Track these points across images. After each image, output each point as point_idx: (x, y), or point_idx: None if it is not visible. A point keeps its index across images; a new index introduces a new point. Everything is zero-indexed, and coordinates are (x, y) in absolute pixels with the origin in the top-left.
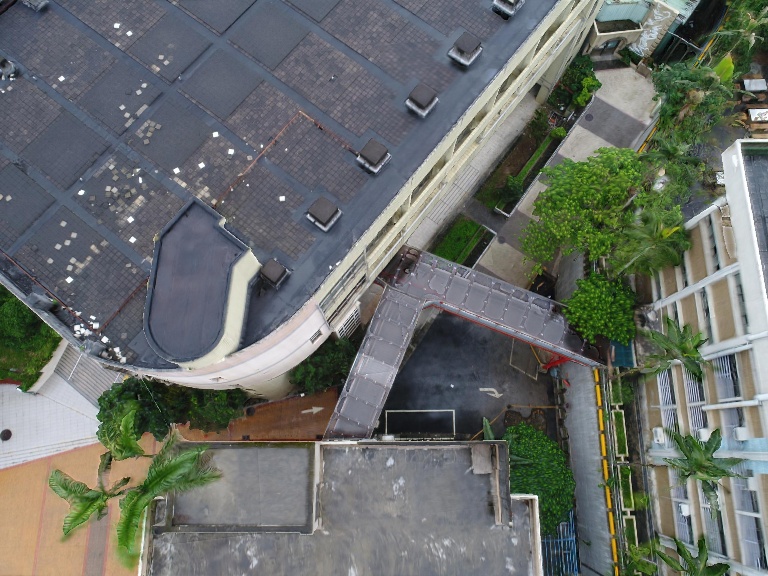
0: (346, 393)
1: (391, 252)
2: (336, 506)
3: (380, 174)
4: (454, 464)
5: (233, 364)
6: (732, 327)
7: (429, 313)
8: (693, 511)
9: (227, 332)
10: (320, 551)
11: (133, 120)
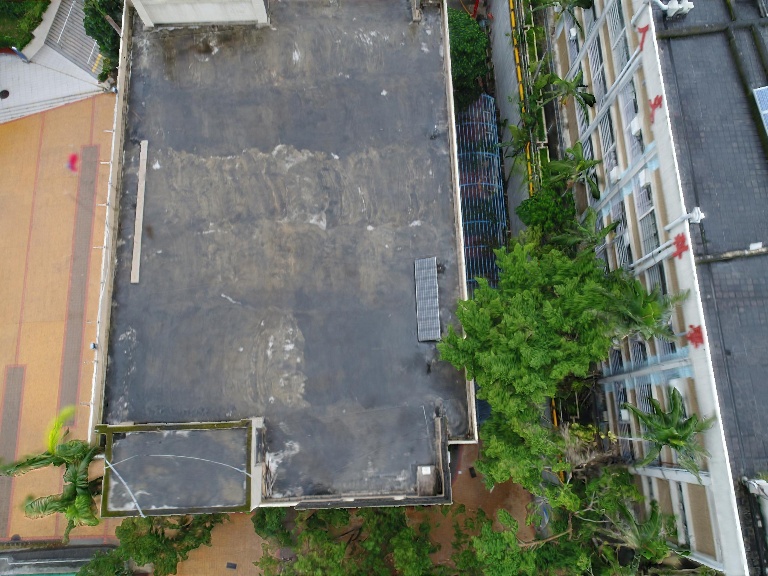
0: None
1: None
2: (282, 11)
3: None
4: None
5: None
6: None
7: None
8: None
9: None
10: (269, 41)
11: None
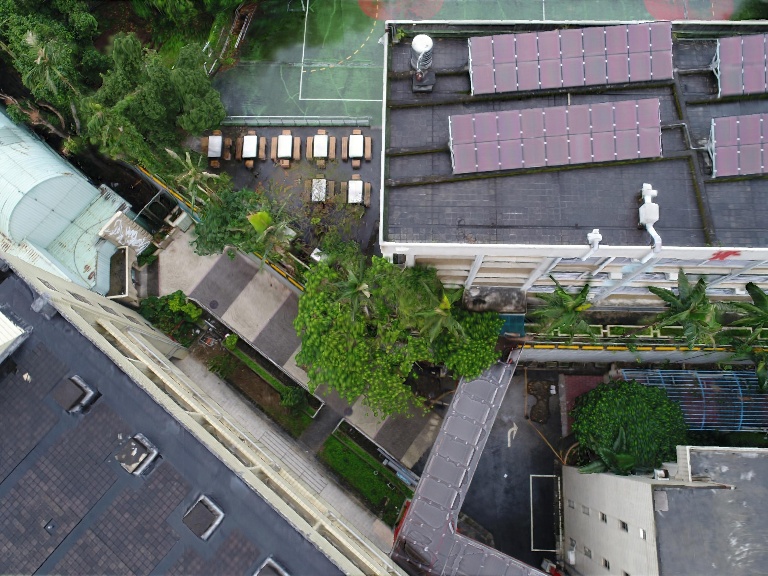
0: None
1: None
2: None
3: None
4: None
5: None
6: None
7: None
8: (669, 285)
9: None
10: None
11: None
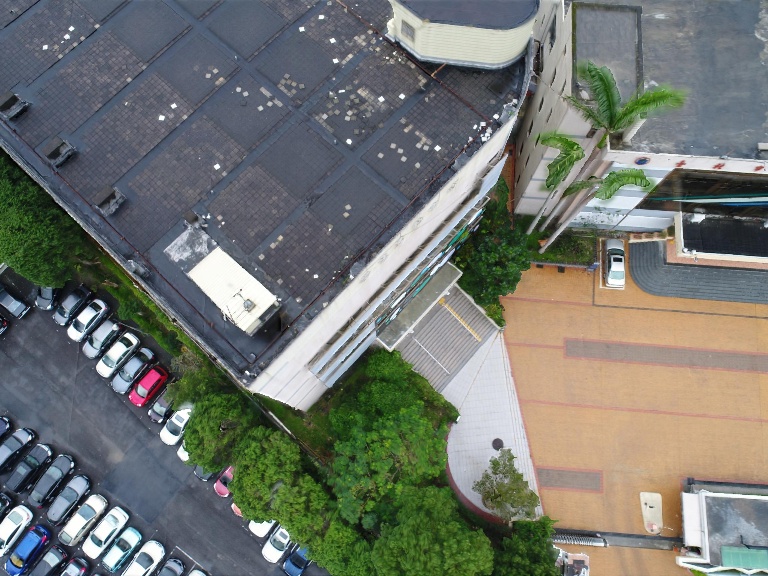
0: None
1: None
2: None
3: None
4: None
5: None
6: None
7: None
8: None
9: None
10: (643, 37)
11: (276, 100)
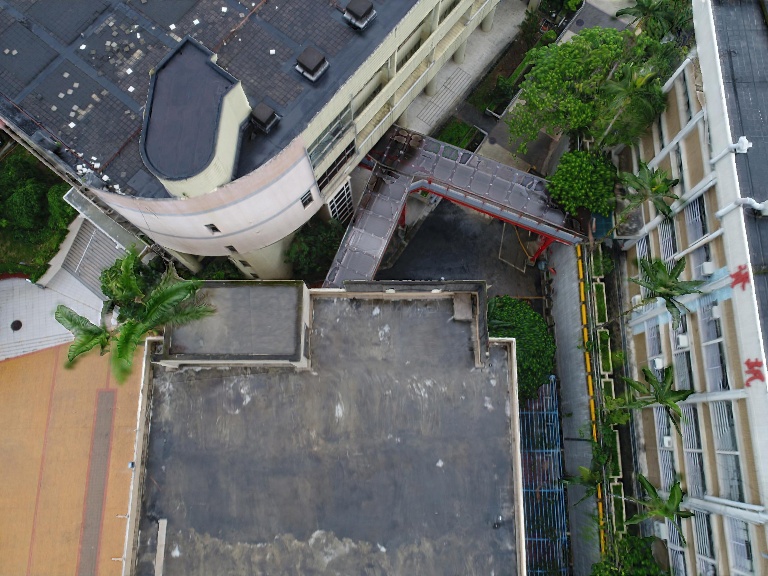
0: (337, 263)
1: (380, 126)
2: (325, 350)
3: (366, 30)
4: (437, 313)
5: (226, 202)
6: (701, 170)
7: (421, 211)
8: (666, 363)
9: (218, 157)
10: (309, 390)
11: None
